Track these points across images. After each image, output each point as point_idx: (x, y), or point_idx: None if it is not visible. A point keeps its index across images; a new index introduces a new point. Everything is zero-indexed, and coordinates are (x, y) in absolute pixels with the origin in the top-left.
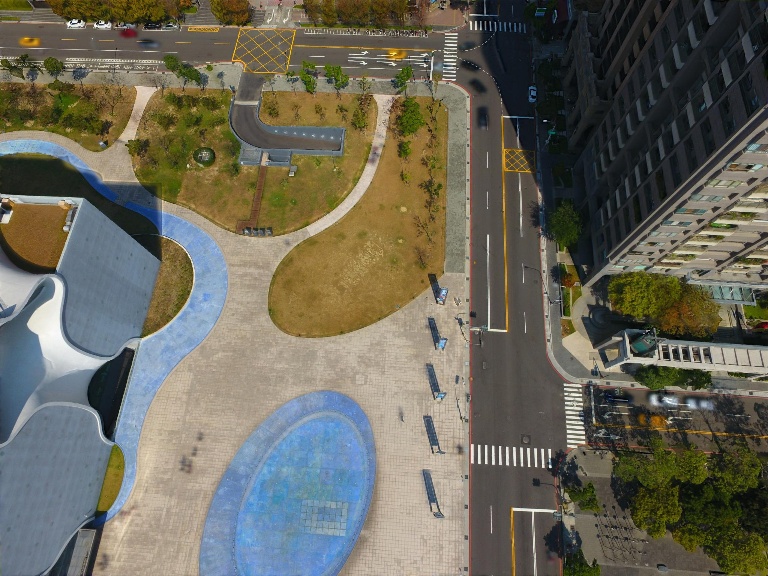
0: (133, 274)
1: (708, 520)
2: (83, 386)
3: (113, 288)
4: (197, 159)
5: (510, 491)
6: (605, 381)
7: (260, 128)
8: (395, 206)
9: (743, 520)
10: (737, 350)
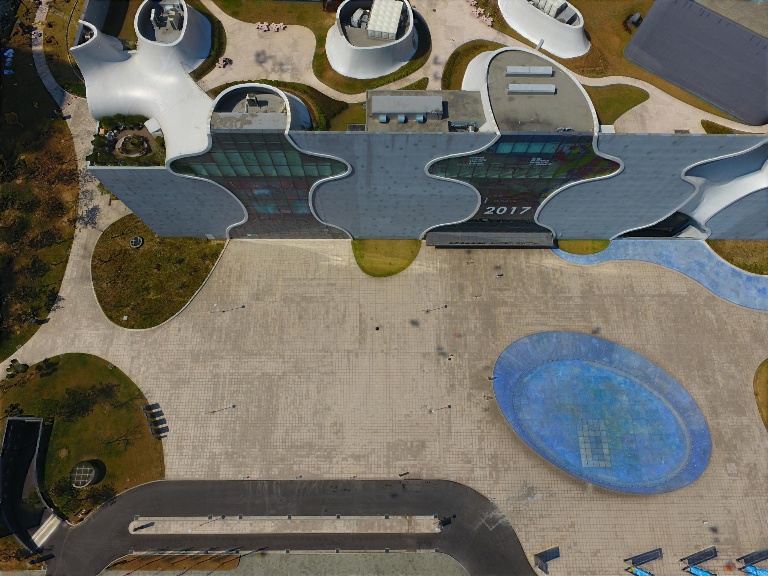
0: None
1: None
2: None
3: None
4: None
5: None
6: None
7: None
8: None
9: None
10: None
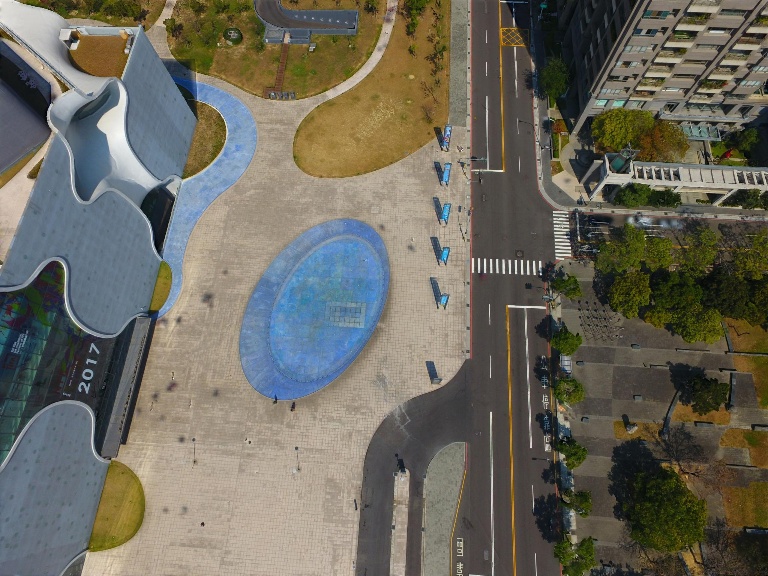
0: (176, 118)
1: (674, 301)
2: (137, 202)
3: (162, 121)
4: (227, 37)
5: (506, 293)
6: (589, 209)
7: (282, 14)
8: (404, 74)
9: (704, 302)
10: (702, 171)
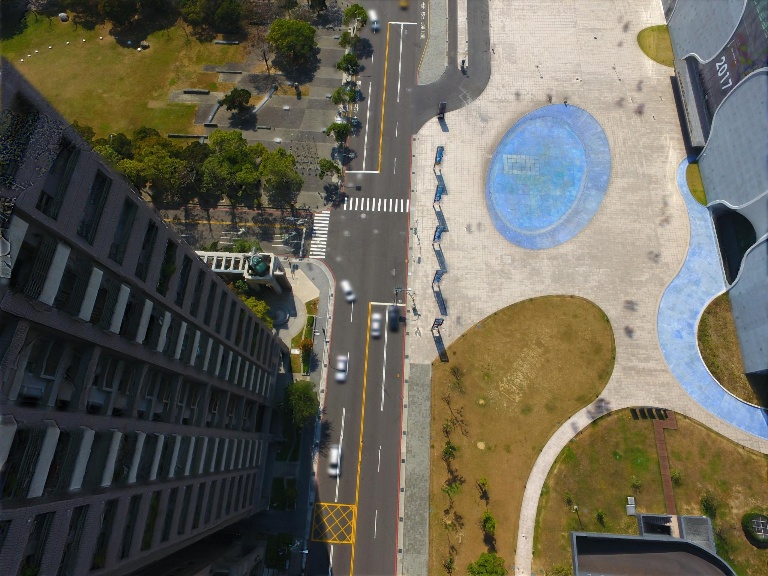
0: None
1: None
2: (761, 227)
3: None
4: (767, 521)
5: (379, 183)
6: None
7: None
8: (492, 450)
9: None
10: None
